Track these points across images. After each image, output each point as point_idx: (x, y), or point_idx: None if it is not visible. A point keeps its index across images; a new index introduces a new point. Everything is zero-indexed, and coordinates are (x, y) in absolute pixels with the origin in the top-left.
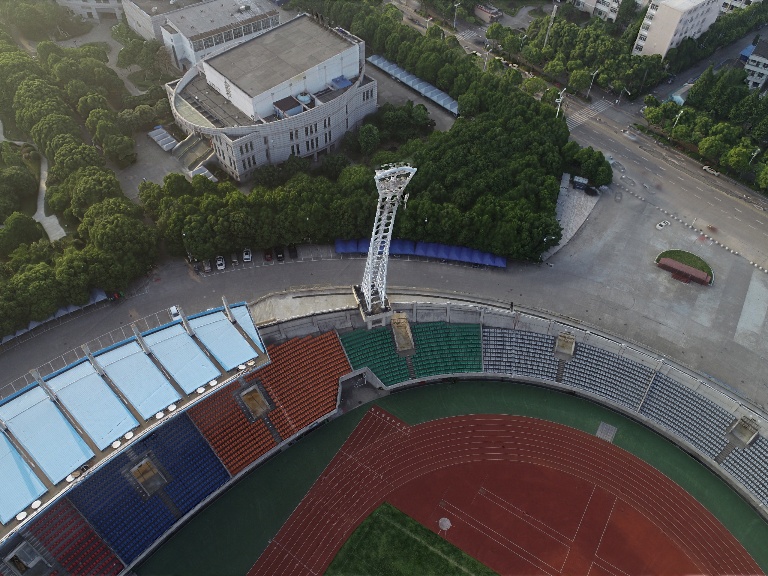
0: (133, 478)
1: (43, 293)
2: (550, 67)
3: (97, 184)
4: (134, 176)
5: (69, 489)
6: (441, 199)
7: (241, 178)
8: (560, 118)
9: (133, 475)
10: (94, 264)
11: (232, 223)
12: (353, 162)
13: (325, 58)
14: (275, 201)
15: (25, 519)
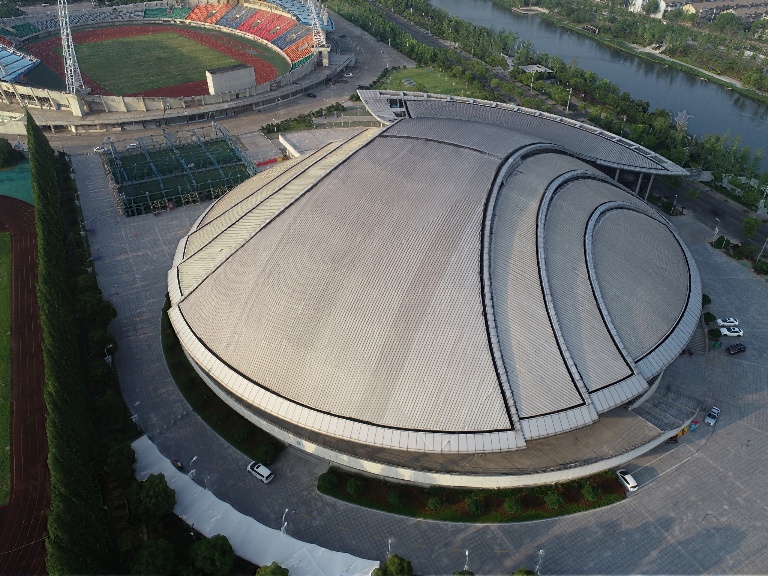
0: None
1: None
2: None
3: None
4: None
5: None
6: None
7: None
8: None
9: None
10: None
11: None
12: None
13: None
14: None
15: None
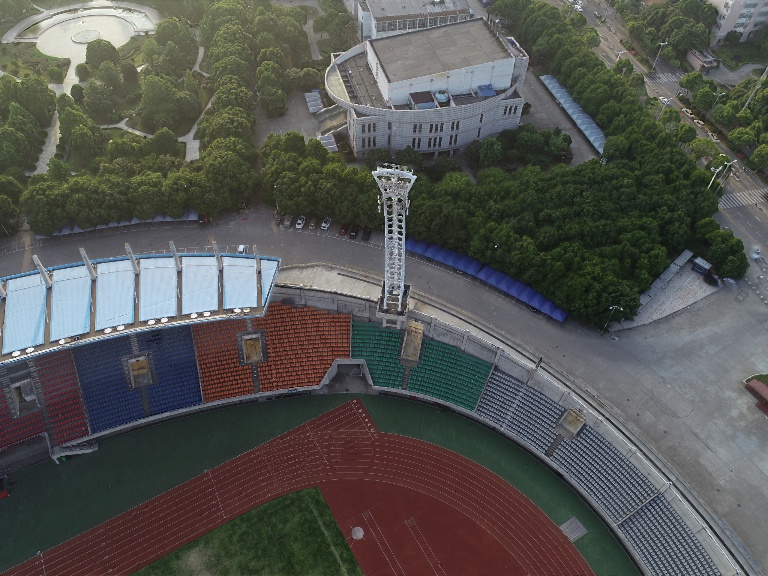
0: (128, 368)
1: (148, 197)
2: (736, 134)
3: (230, 122)
4: (276, 127)
5: (56, 349)
6: (526, 231)
7: (358, 155)
8: (713, 190)
9: (129, 365)
10: (195, 187)
11: (318, 189)
12: (470, 171)
13: (477, 63)
14: (364, 182)
15: (16, 357)
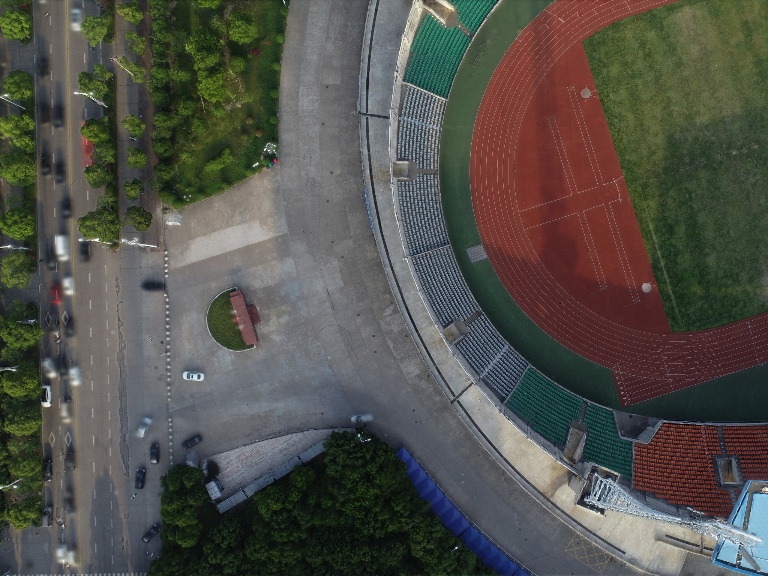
0: None
1: None
2: None
3: None
4: None
5: None
6: (408, 568)
7: None
8: None
9: None
10: None
11: None
12: None
13: None
14: None
15: None
